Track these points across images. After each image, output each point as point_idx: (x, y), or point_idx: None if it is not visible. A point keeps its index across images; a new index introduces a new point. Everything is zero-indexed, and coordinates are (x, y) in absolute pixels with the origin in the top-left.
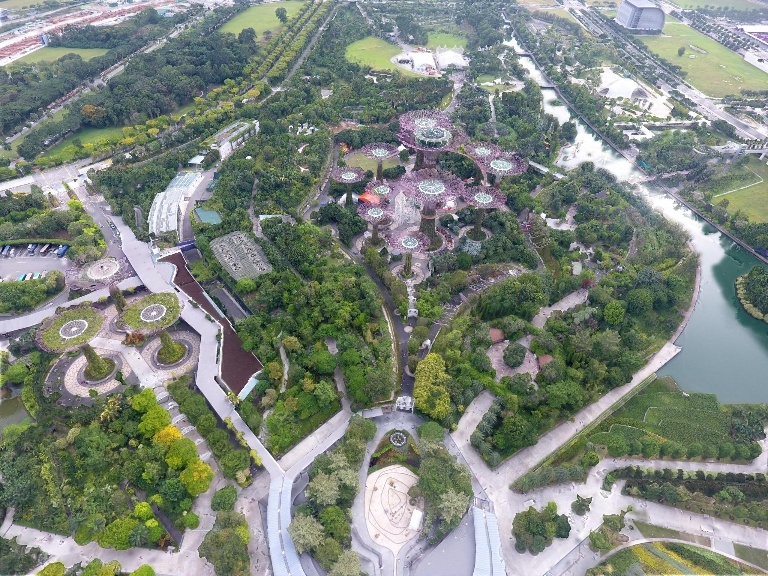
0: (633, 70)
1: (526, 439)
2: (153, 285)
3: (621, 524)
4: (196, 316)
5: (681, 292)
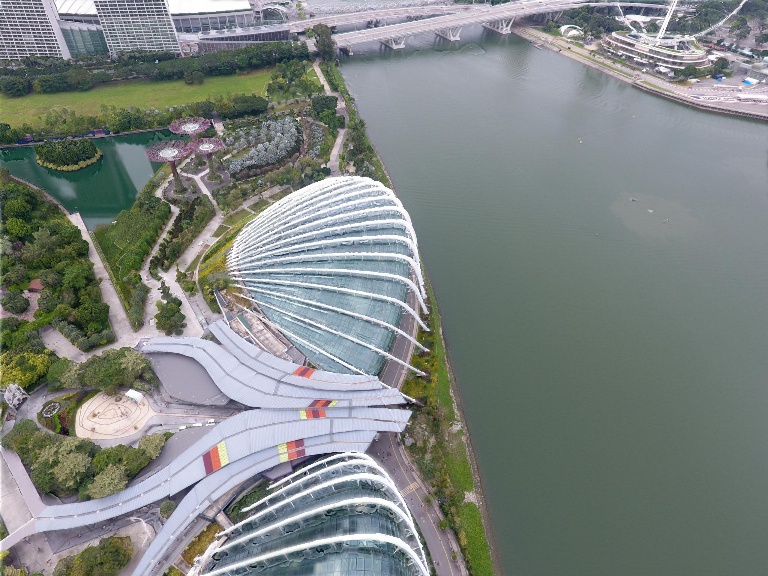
0: None
1: (102, 311)
2: None
3: None
4: None
5: None
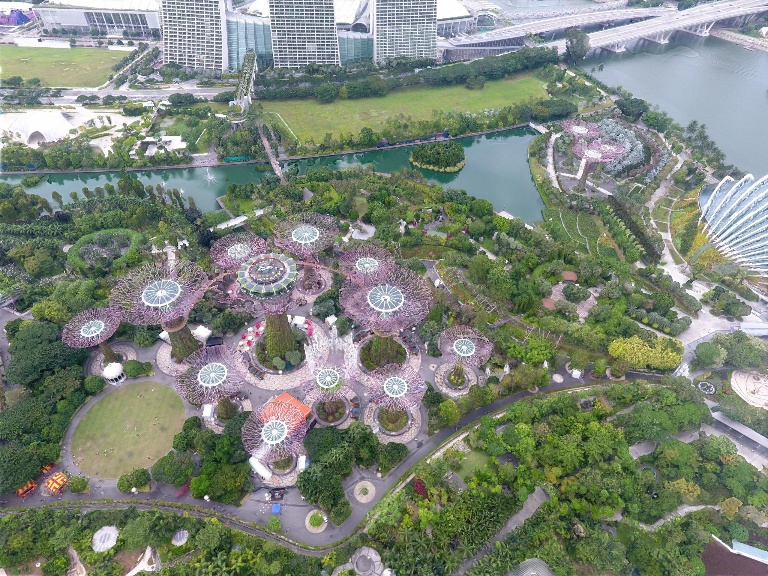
0: None
1: None
2: None
3: None
4: None
5: None
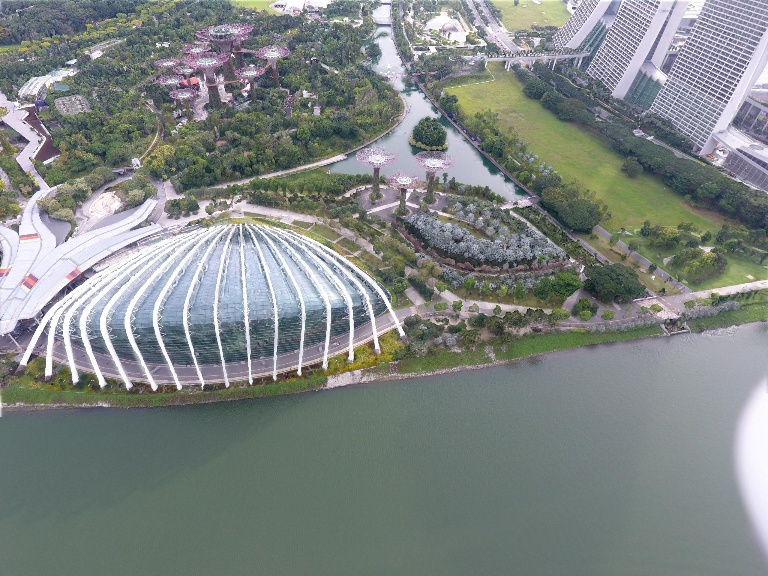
0: (463, 13)
1: (202, 180)
2: (8, 120)
3: (227, 205)
4: (31, 134)
5: (373, 132)
